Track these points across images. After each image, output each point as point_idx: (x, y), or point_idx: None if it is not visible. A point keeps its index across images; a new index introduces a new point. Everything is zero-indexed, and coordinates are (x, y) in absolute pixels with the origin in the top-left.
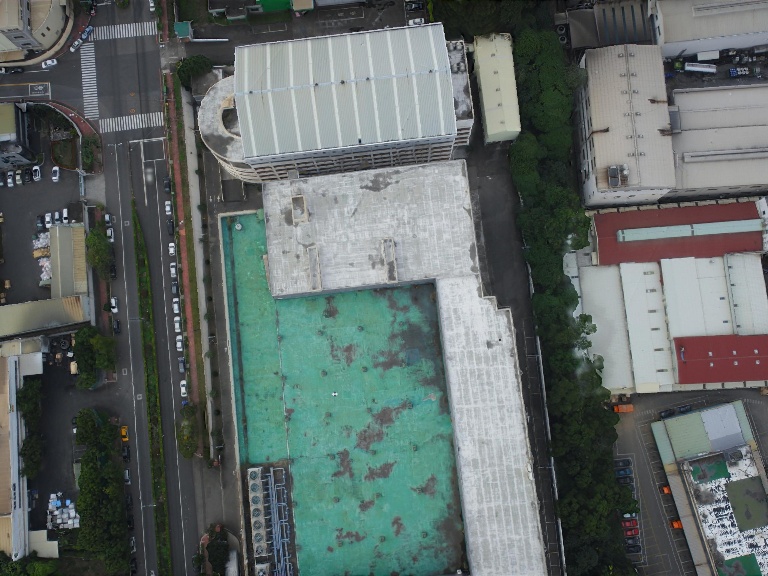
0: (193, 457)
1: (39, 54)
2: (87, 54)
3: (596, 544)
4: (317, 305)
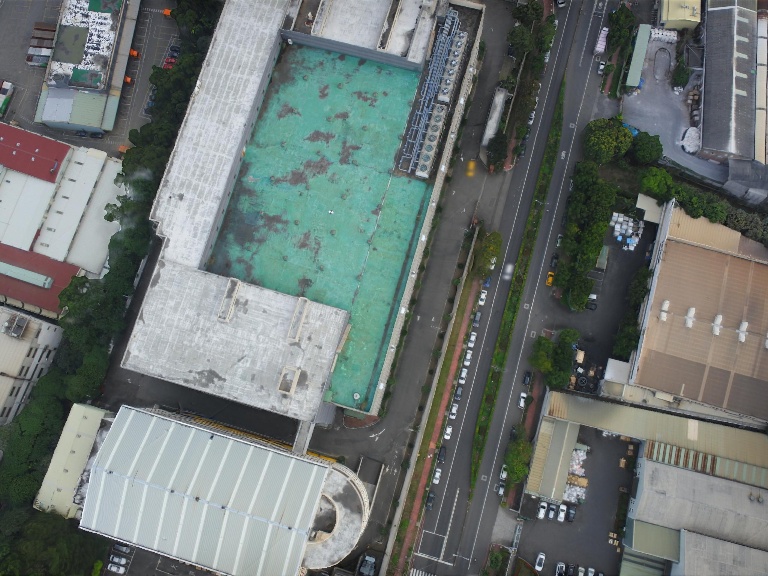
0: None
1: None
2: None
3: (194, 50)
4: (315, 294)
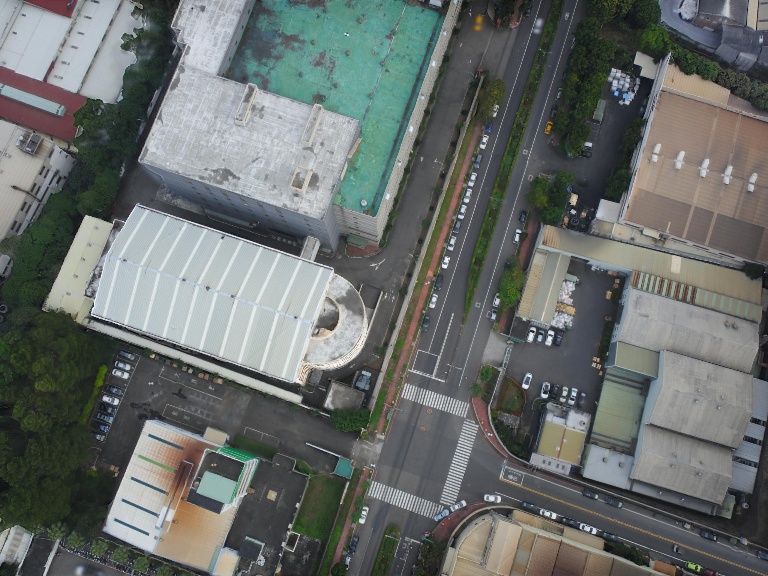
0: None
1: (499, 512)
2: (451, 493)
3: None
4: (328, 109)
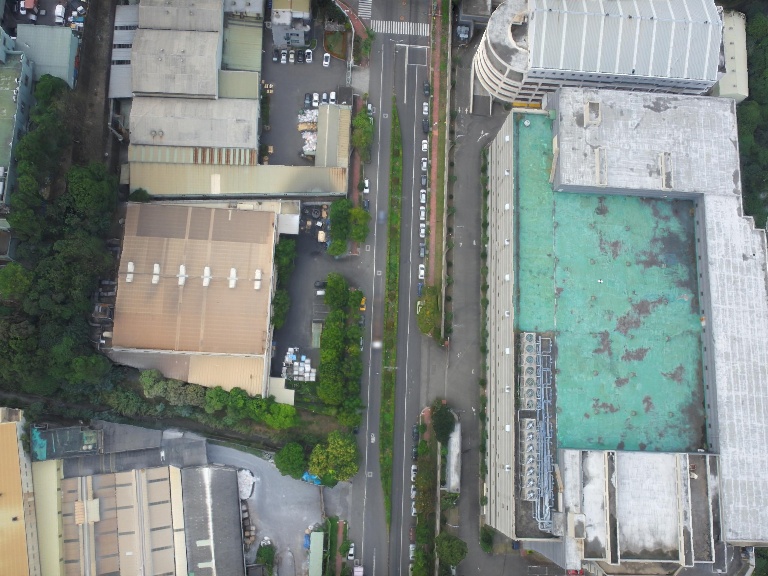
0: (423, 335)
1: None
2: None
3: None
4: (590, 202)
